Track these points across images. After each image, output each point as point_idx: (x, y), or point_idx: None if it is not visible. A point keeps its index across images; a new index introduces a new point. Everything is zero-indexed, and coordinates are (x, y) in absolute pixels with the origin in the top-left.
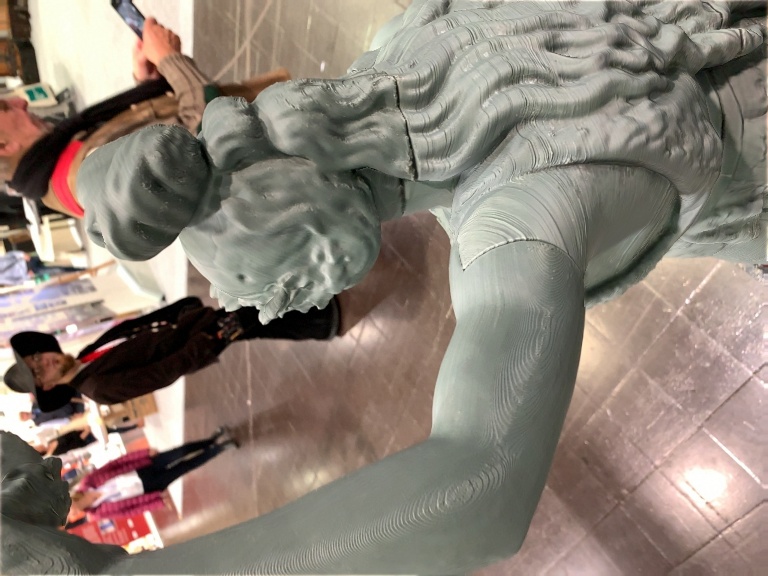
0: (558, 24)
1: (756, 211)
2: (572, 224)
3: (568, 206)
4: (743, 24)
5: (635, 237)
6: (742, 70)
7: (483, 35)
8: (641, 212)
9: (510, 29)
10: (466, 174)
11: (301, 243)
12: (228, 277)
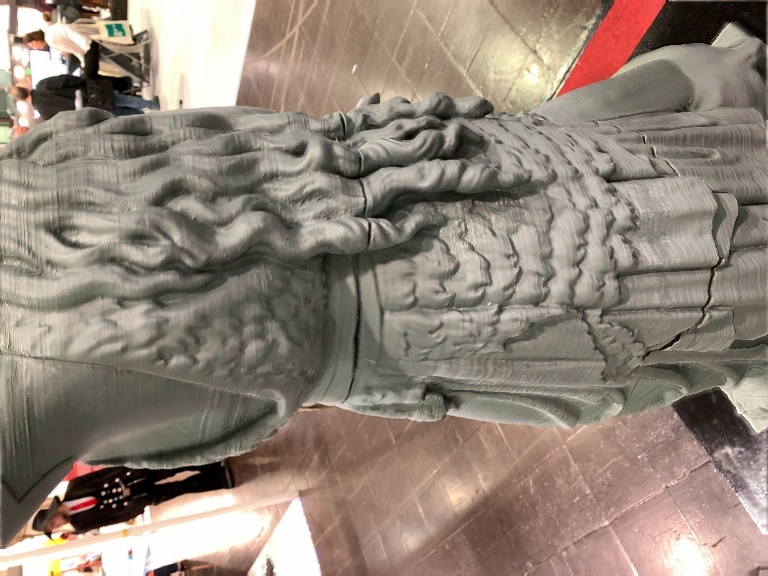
0: (86, 201)
1: (413, 400)
2: (4, 423)
3: (6, 403)
4: (418, 208)
5: (204, 416)
6: (391, 260)
7: (0, 198)
8: (174, 403)
9: (22, 200)
10: None
11: None
12: None
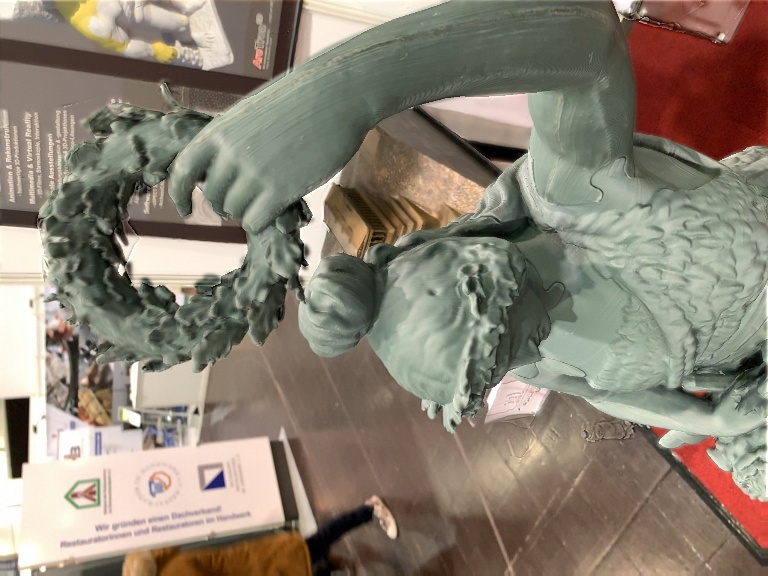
0: None
1: None
2: None
3: None
4: None
5: None
6: None
7: None
8: None
9: None
10: (526, 209)
11: (453, 256)
12: (425, 304)
